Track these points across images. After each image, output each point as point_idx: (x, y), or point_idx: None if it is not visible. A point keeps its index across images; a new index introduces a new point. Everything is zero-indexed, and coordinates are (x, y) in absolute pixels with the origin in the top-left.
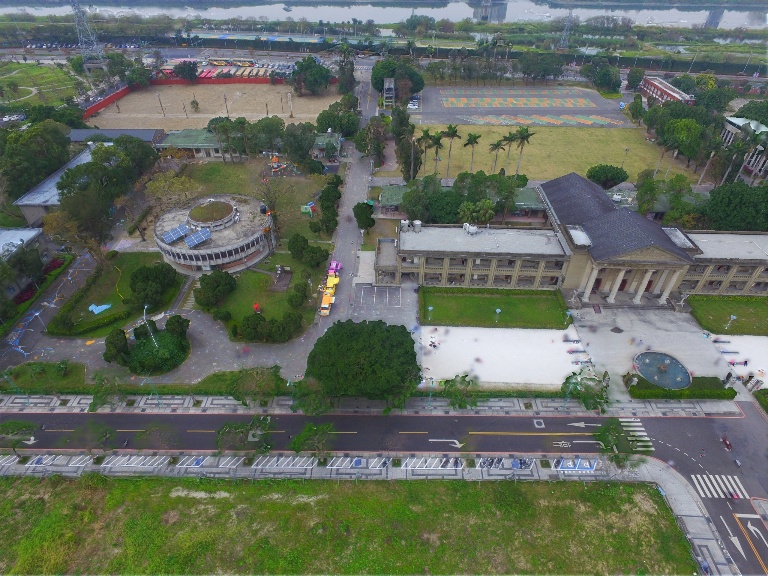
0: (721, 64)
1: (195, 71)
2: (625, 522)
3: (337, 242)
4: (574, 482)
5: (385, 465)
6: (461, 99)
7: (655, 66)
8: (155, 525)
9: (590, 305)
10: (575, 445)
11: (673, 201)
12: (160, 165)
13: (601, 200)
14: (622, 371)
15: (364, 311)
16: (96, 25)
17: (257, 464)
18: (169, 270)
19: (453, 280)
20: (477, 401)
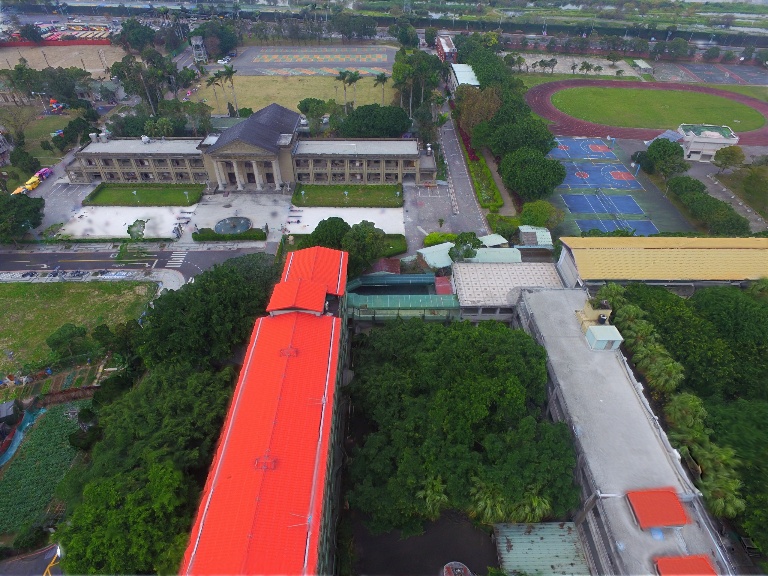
0: (524, 25)
1: (40, 34)
2: (117, 298)
3: (66, 158)
4: (104, 281)
5: None
6: (273, 56)
7: (470, 27)
8: None
9: (222, 192)
10: (127, 265)
11: (330, 121)
12: None
13: (280, 122)
14: None
15: (47, 199)
16: None
17: None
18: None
19: (130, 178)
20: (81, 245)
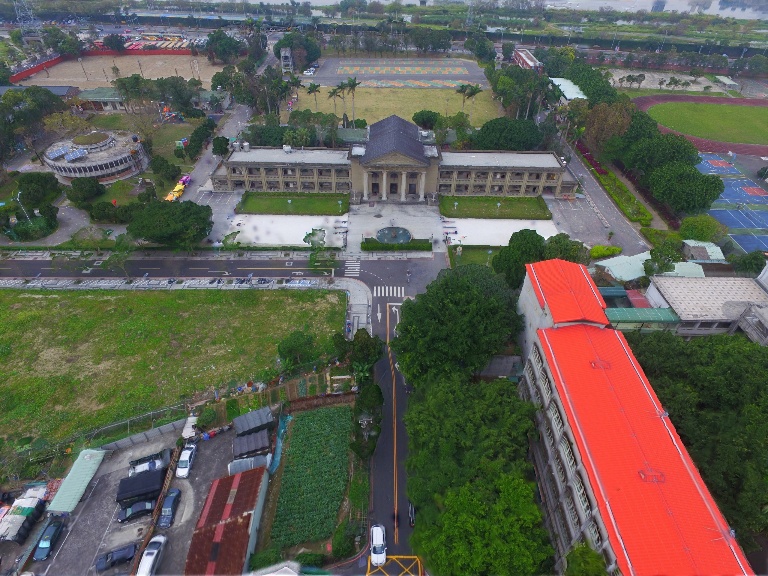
0: (593, 40)
1: (123, 43)
2: (313, 306)
3: (197, 166)
4: (292, 289)
5: (170, 283)
6: (355, 68)
7: None
8: (4, 309)
9: (368, 202)
10: (307, 273)
11: (457, 133)
12: (72, 115)
13: (406, 133)
14: (365, 237)
15: None
16: (33, 1)
17: (84, 283)
18: (51, 178)
19: (272, 187)
20: (252, 253)
